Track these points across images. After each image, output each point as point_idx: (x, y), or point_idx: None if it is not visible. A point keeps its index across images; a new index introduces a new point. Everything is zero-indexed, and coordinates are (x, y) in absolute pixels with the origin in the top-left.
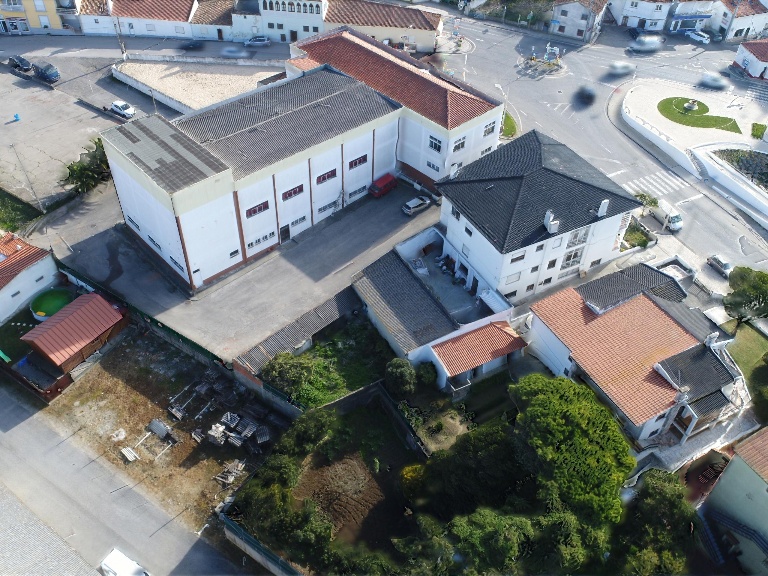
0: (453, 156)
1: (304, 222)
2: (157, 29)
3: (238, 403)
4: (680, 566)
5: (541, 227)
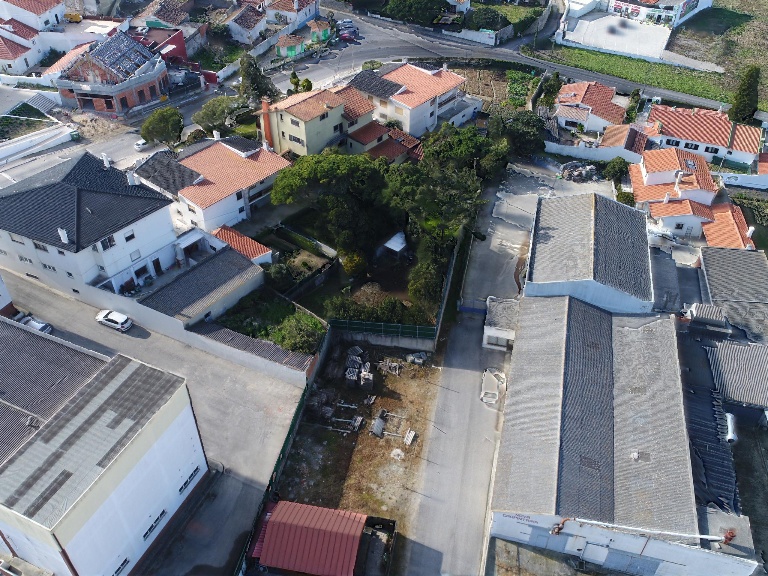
0: None
1: None
2: None
3: (328, 388)
4: (367, 153)
5: (136, 186)
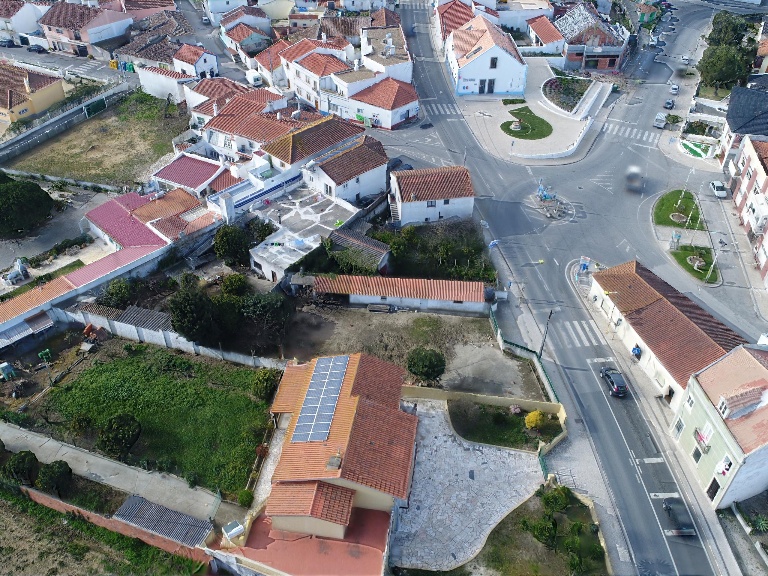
0: None
1: None
2: None
3: None
4: None
5: None
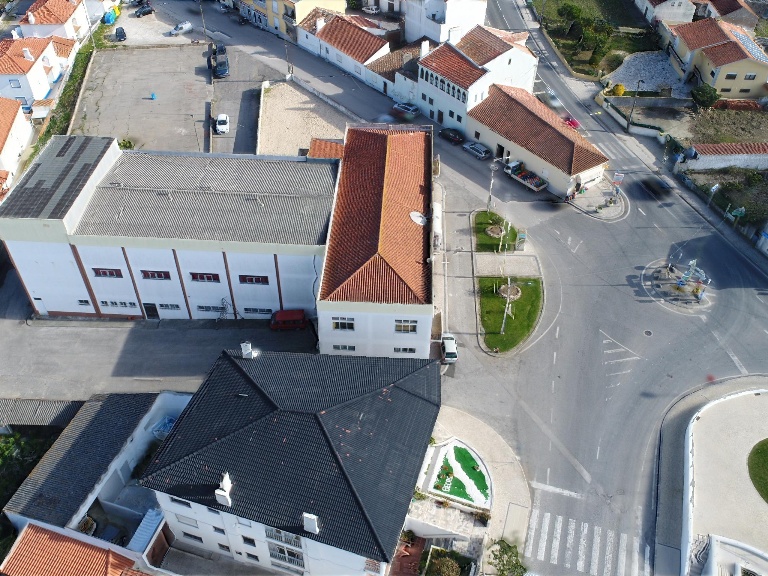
0: (333, 332)
1: (179, 310)
2: (343, 61)
3: None
4: None
5: (217, 486)
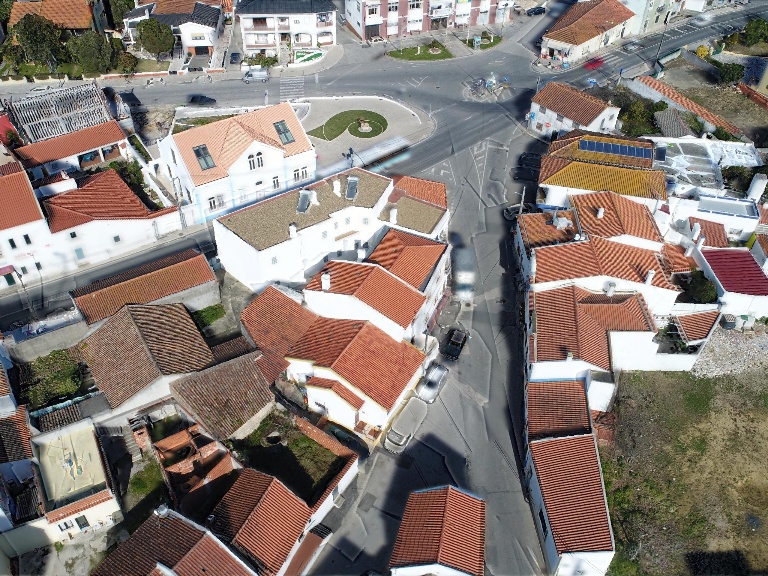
0: None
1: None
2: None
3: None
4: None
5: None
